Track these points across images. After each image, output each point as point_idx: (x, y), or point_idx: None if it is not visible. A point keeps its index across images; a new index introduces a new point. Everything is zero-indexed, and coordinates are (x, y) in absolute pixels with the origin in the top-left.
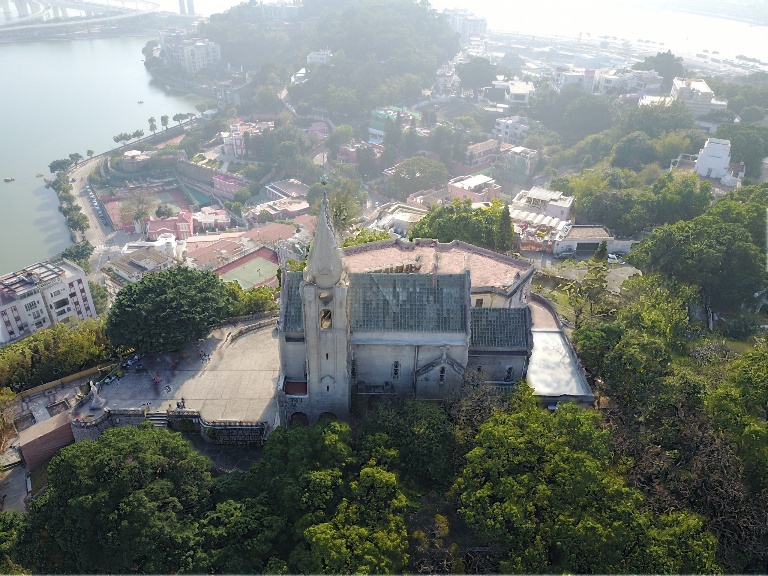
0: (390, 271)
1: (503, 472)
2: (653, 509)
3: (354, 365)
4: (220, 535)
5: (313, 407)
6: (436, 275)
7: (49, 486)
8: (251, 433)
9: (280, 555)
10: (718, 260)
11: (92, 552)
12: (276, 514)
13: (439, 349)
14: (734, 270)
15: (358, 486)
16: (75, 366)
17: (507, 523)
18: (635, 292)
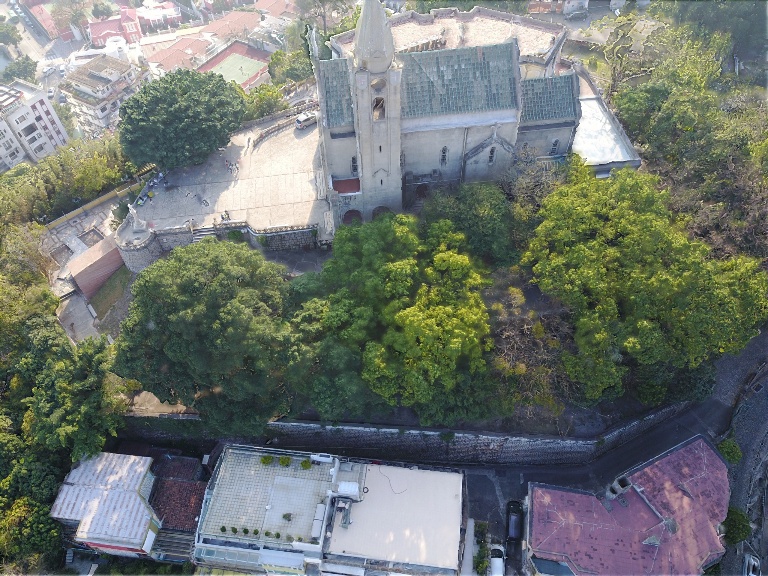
0: (416, 50)
1: (567, 242)
2: (710, 258)
3: (401, 156)
4: (317, 330)
5: (367, 203)
6: (481, 47)
7: (131, 308)
8: (303, 236)
9: (374, 340)
10: (752, 1)
11: (203, 359)
12: (360, 305)
13: (489, 129)
14: (766, 11)
15: (434, 271)
16: (94, 192)
17: (584, 286)
18: (663, 47)
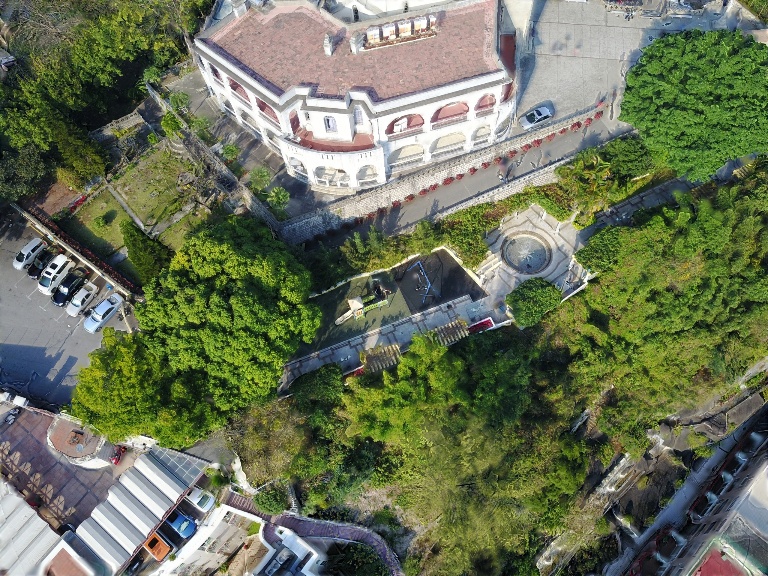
0: None
1: None
2: None
3: None
4: None
5: None
6: None
7: None
8: None
9: None
10: None
11: None
12: None
13: None
14: None
15: None
16: None
17: None
18: None
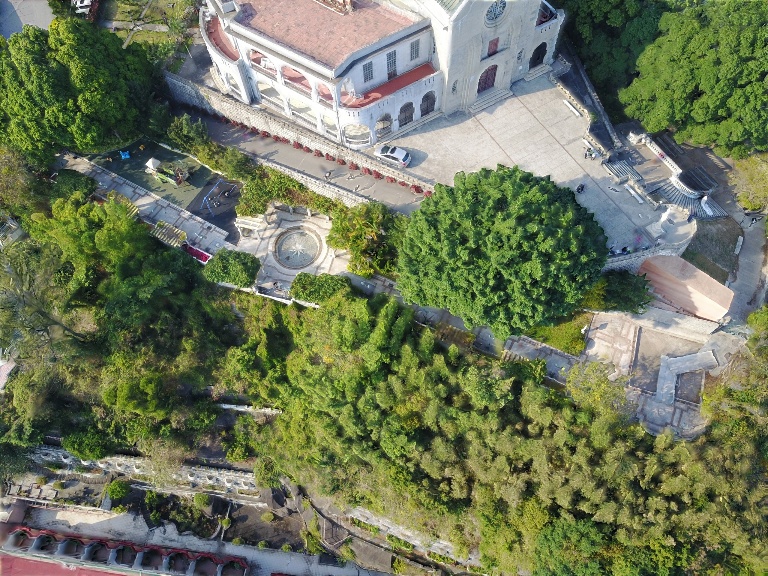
0: None
1: None
2: None
3: None
4: None
5: None
6: None
7: None
8: None
9: None
10: None
11: None
12: None
13: None
14: None
15: None
16: None
17: None
18: None
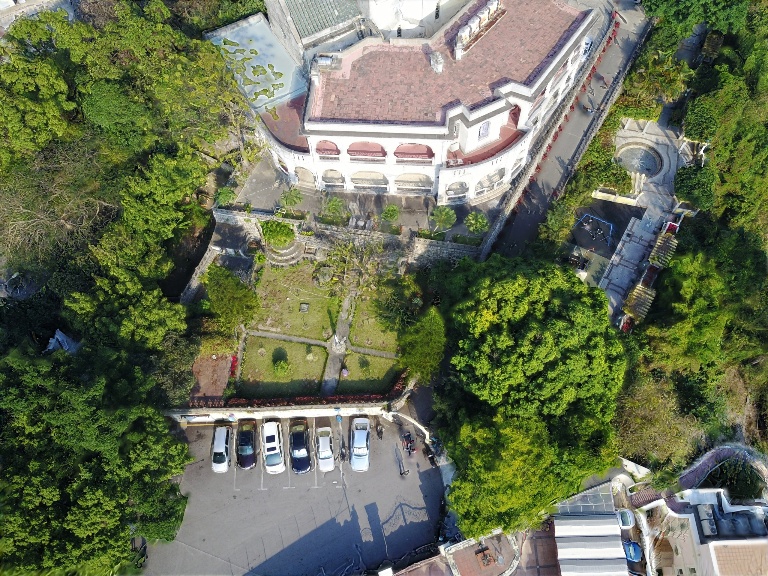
0: None
1: None
2: None
3: None
4: None
5: None
6: None
7: None
8: None
9: None
10: None
11: None
12: None
13: None
14: None
15: None
16: None
17: None
18: None
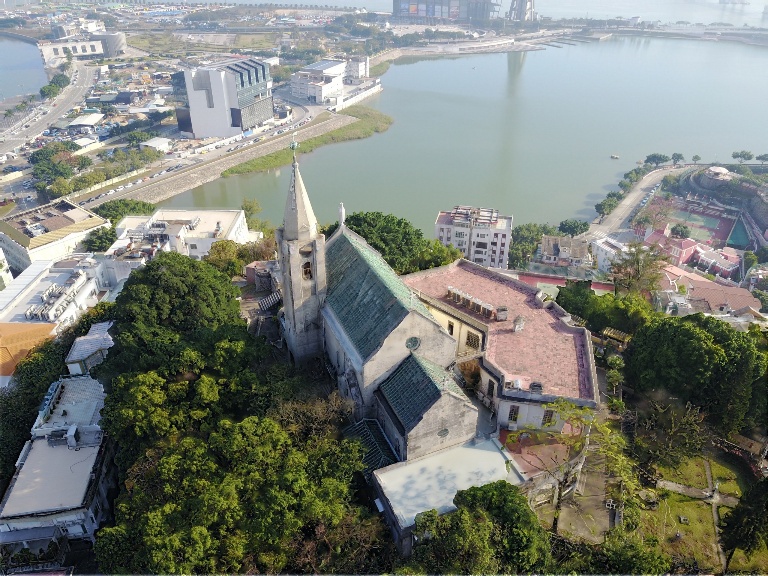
0: (466, 302)
1: None
2: None
3: None
4: (142, 339)
5: (287, 340)
6: (396, 300)
7: None
8: None
9: None
10: None
11: None
12: None
13: None
14: None
15: None
16: None
17: None
18: None
